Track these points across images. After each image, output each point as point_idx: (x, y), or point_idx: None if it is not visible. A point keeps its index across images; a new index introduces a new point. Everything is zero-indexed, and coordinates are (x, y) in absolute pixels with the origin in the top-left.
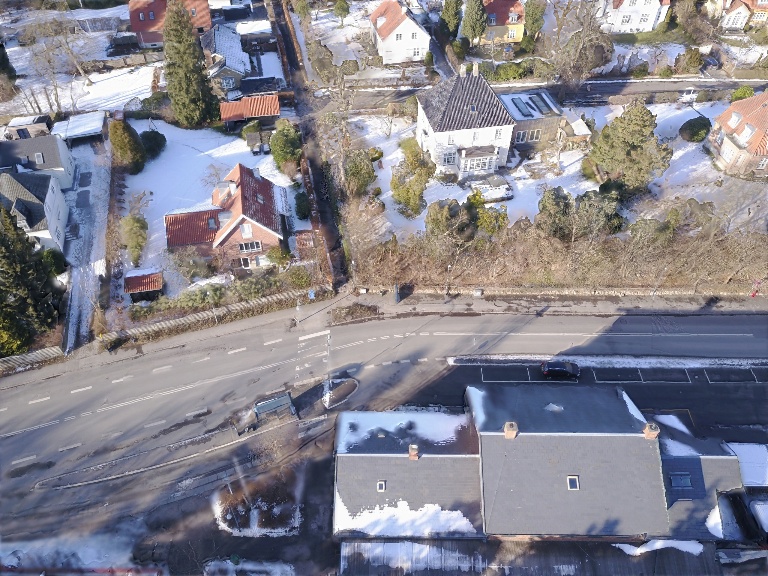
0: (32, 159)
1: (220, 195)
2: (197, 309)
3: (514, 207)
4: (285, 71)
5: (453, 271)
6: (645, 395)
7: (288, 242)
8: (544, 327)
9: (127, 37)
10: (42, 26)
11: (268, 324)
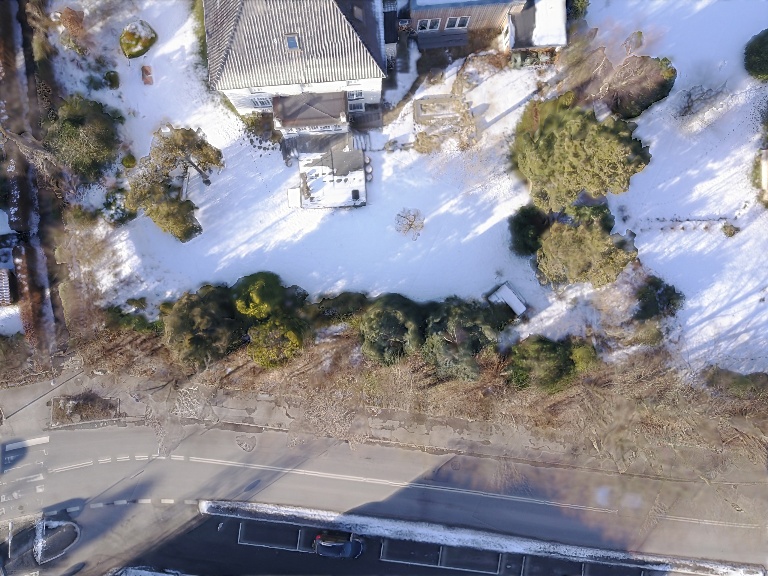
0: None
1: None
2: None
3: (361, 228)
4: None
5: (232, 359)
6: None
7: None
8: (343, 464)
9: None
10: None
11: None
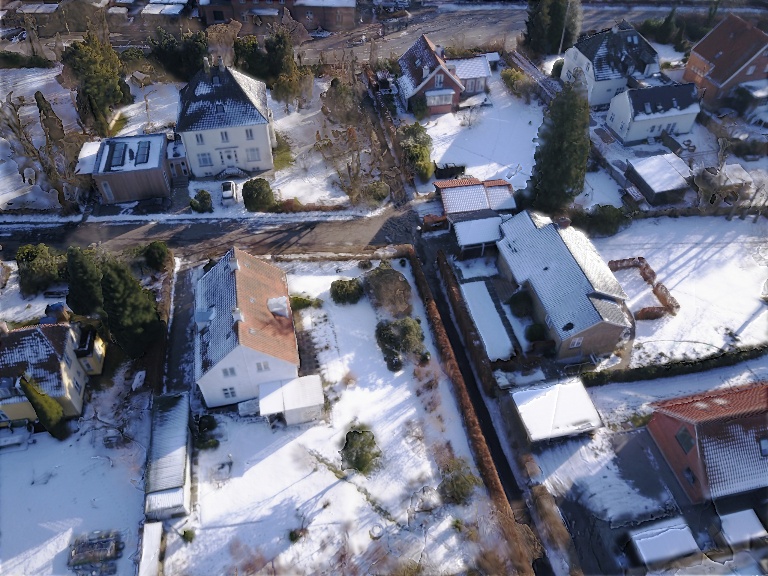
0: None
1: None
2: None
3: None
4: None
5: None
6: None
7: None
8: None
9: None
10: None
11: None
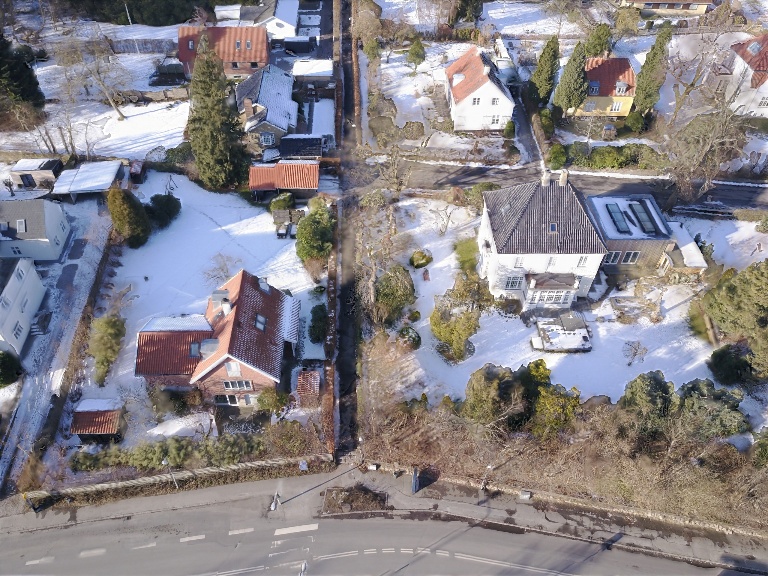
0: (13, 226)
1: (214, 308)
2: (152, 472)
3: (591, 365)
4: (336, 129)
5: None
6: None
7: (291, 376)
8: (611, 570)
9: (173, 66)
10: (71, 54)
11: (241, 500)
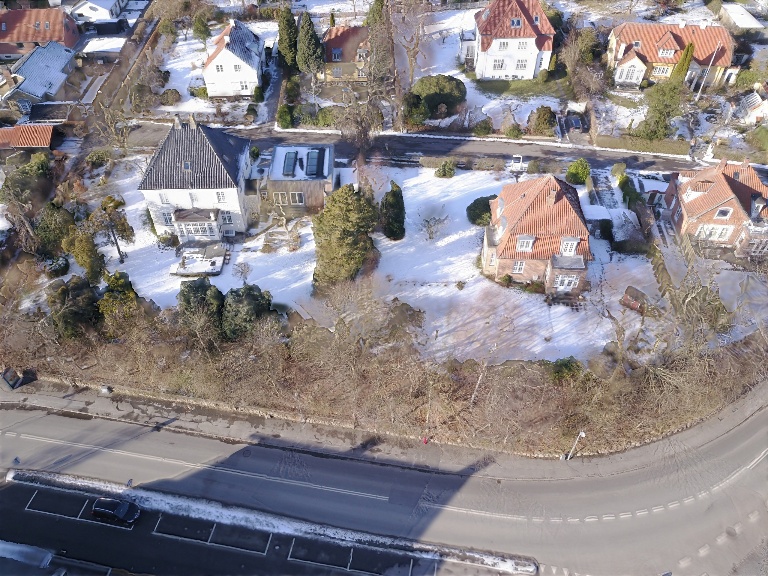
0: None
1: None
2: None
3: None
4: None
5: (90, 359)
6: (196, 562)
7: None
8: (148, 446)
9: None
10: None
11: None
